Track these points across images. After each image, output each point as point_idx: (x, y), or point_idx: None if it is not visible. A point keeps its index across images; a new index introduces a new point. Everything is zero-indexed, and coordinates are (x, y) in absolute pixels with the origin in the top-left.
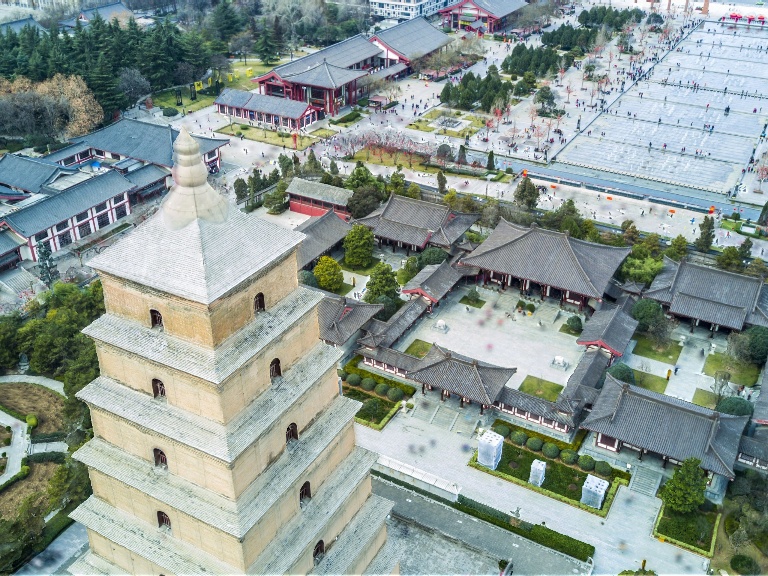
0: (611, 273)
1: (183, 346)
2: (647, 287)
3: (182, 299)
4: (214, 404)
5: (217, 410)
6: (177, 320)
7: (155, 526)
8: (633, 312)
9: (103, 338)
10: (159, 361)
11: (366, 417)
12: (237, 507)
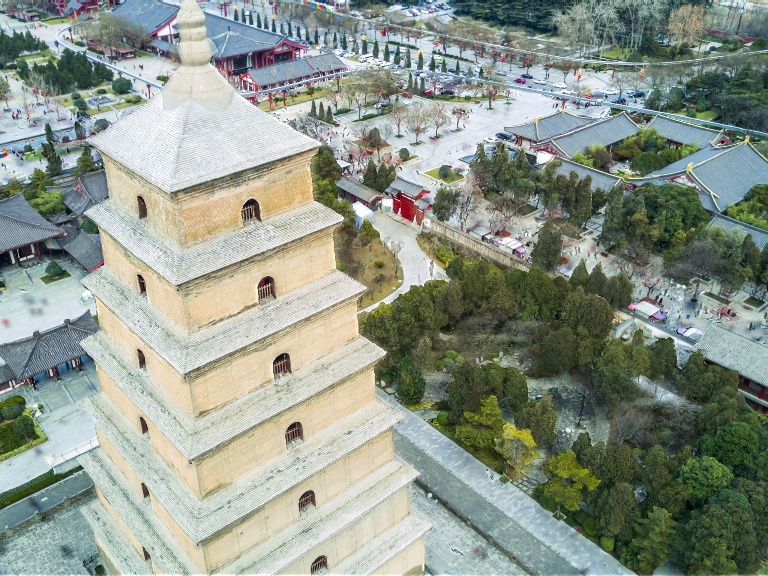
0: (39, 215)
1: (287, 217)
2: (68, 213)
3: (291, 159)
4: (328, 254)
5: (331, 258)
6: (277, 193)
7: (283, 452)
8: (87, 232)
9: (209, 269)
10: (283, 243)
11: (19, 444)
12: (363, 340)
